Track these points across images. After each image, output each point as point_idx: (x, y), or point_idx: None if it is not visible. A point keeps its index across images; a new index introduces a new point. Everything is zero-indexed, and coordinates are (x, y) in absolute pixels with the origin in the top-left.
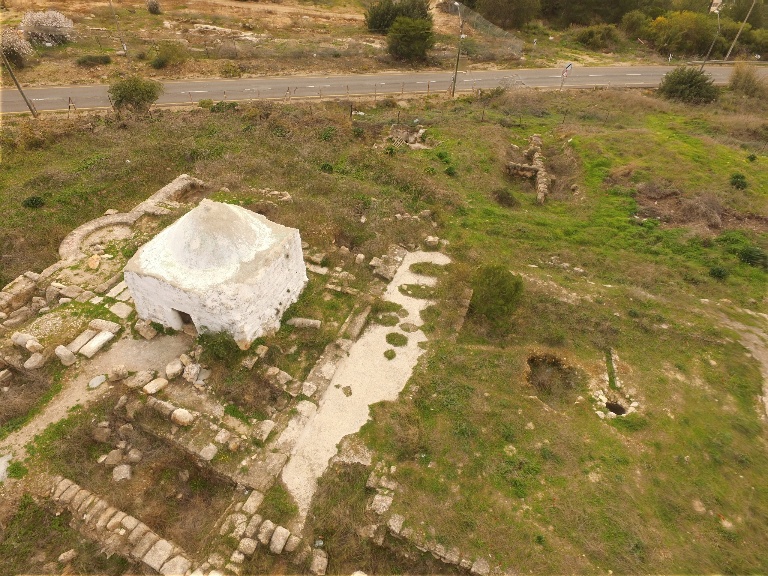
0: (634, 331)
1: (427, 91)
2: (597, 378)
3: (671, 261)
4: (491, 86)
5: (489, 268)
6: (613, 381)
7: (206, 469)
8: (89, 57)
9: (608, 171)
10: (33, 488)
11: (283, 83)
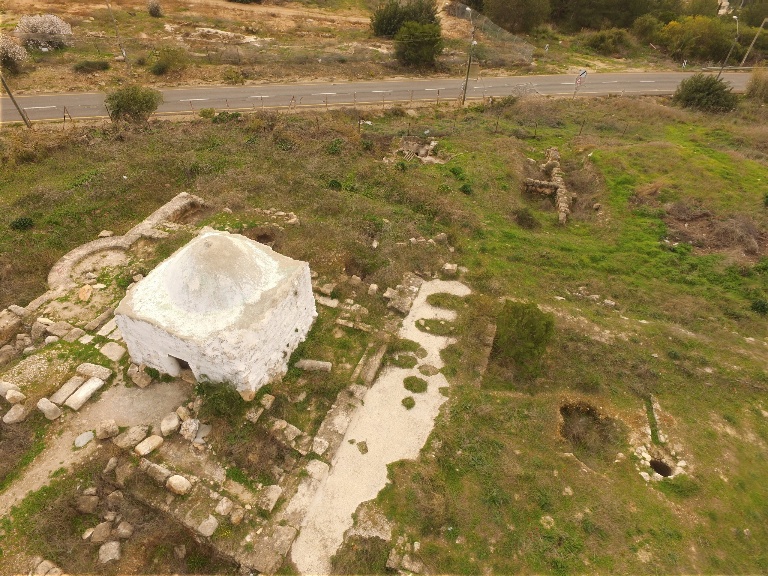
0: (675, 375)
1: (436, 99)
2: (638, 431)
3: (709, 292)
4: (502, 93)
5: (517, 307)
6: (656, 435)
7: (205, 546)
8: (87, 63)
9: (633, 189)
10: (7, 572)
11: (287, 90)
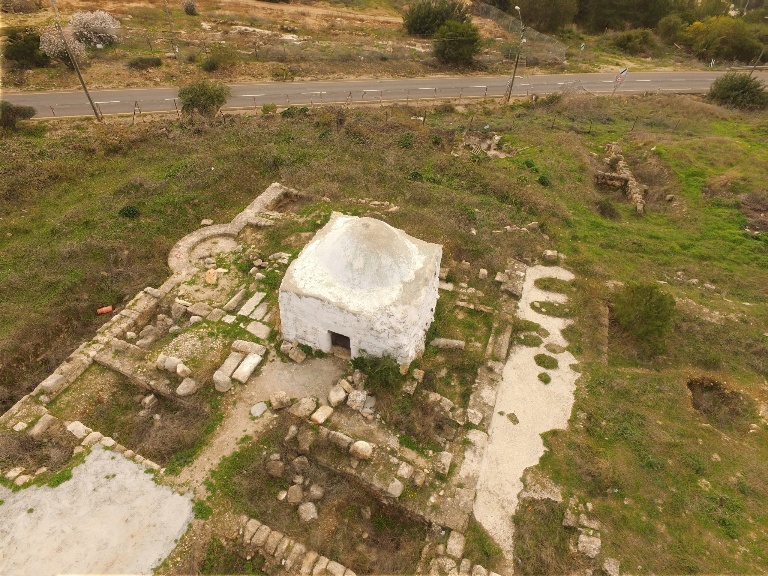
0: None
1: (483, 96)
2: (766, 404)
3: None
4: (543, 91)
5: (644, 287)
6: None
7: (394, 507)
8: (140, 59)
9: (704, 181)
10: (220, 529)
11: (337, 87)
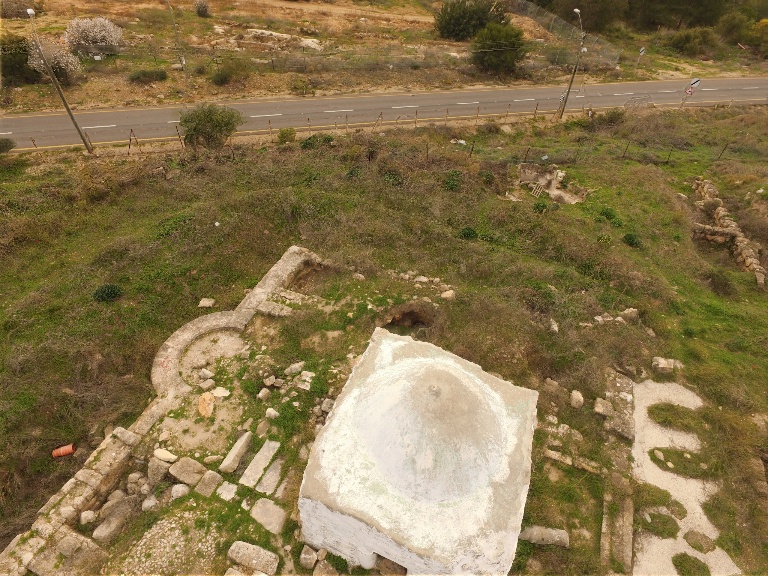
0: None
1: (532, 113)
2: None
3: None
4: (599, 104)
5: None
6: None
7: None
8: (143, 72)
9: None
10: None
11: (365, 103)
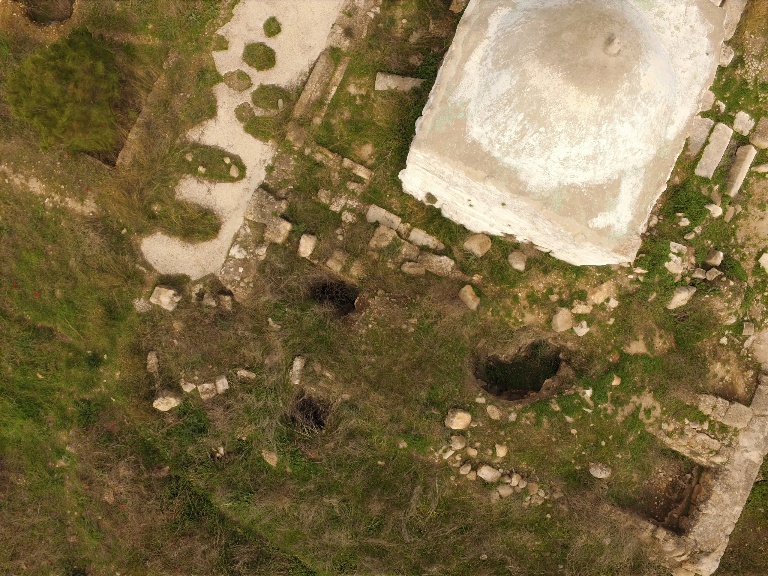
0: None
1: None
2: None
3: None
4: None
5: None
6: None
7: None
8: None
9: None
10: None
11: None
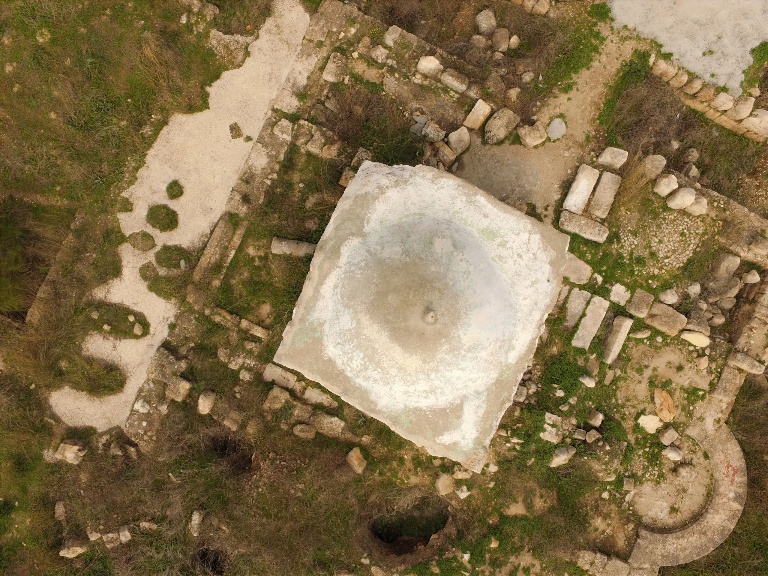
0: None
1: None
2: None
3: None
4: None
5: None
6: None
7: None
8: None
9: None
10: (575, 4)
11: None
